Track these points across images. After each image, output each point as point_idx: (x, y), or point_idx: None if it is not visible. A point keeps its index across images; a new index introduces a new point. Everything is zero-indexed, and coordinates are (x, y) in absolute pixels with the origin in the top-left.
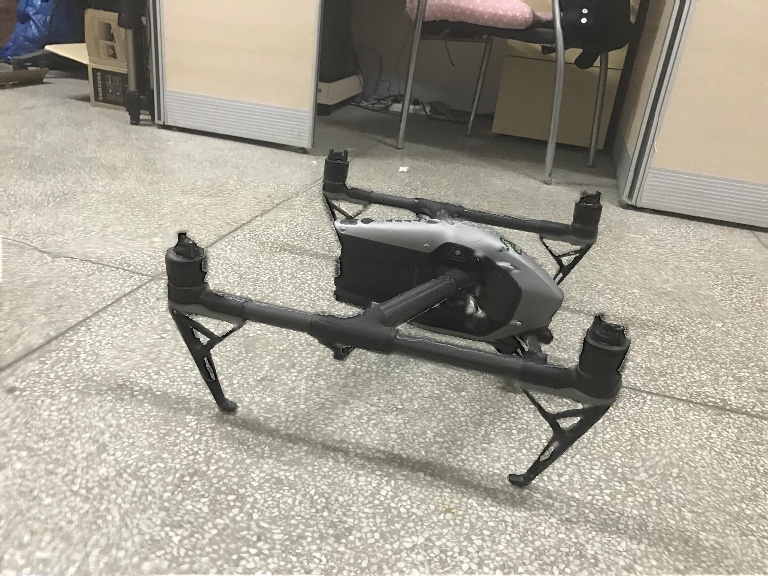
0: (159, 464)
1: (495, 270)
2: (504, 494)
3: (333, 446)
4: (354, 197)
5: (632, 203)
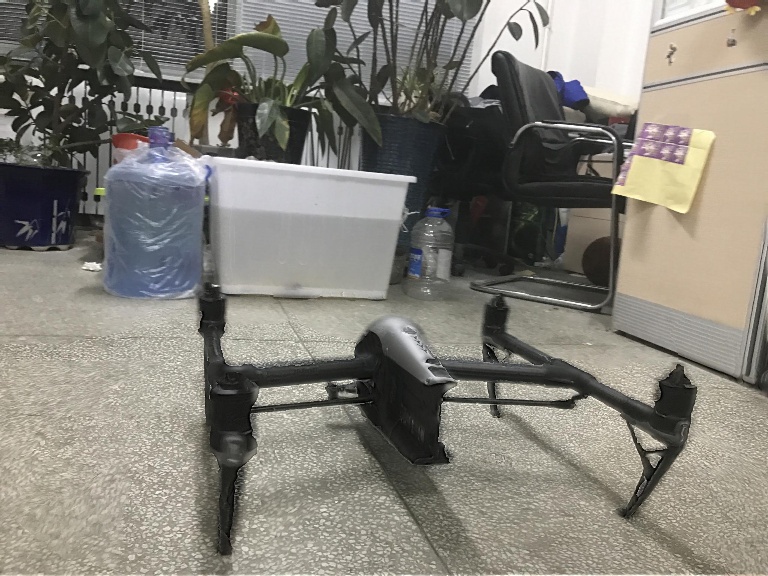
0: (705, 513)
1: None
2: (511, 418)
3: (572, 466)
4: None
5: None
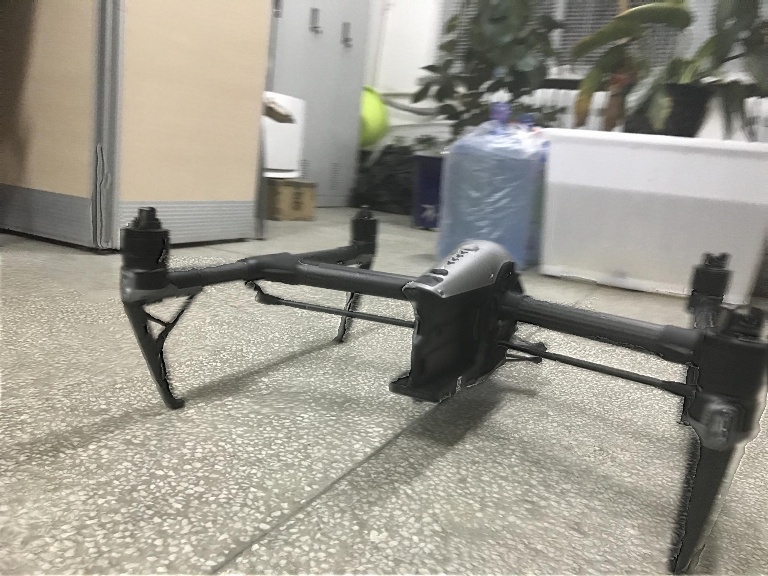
0: None
1: (514, 279)
2: None
3: None
4: (179, 286)
5: (104, 248)
